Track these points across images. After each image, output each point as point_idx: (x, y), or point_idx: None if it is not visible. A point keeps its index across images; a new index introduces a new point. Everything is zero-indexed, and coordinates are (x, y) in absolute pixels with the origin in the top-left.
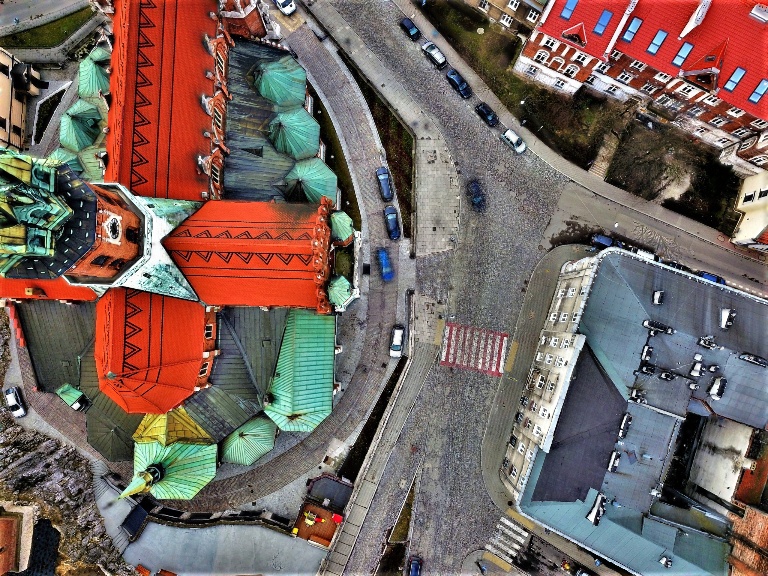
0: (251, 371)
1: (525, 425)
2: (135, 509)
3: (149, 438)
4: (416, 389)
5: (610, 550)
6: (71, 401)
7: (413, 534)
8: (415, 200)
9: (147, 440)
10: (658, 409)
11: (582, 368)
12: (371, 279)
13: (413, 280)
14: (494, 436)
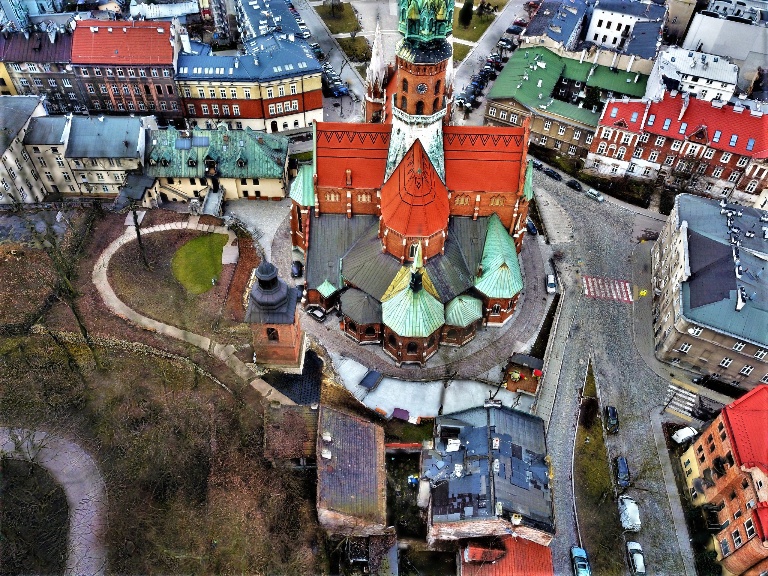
0: (465, 259)
1: (664, 307)
2: (370, 373)
3: (397, 292)
4: (573, 308)
5: (764, 338)
6: (328, 293)
7: (601, 393)
8: (541, 218)
9: (395, 294)
10: (753, 250)
11: (692, 237)
12: (523, 254)
13: (552, 255)
14: (642, 335)
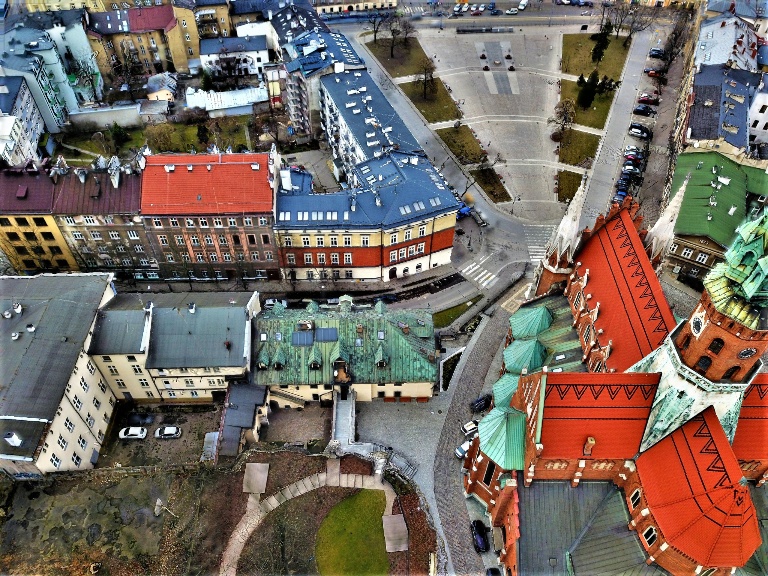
0: (756, 557)
1: None
2: None
3: None
4: None
5: None
6: None
7: None
8: None
9: None
10: None
11: None
12: None
13: None
14: None
